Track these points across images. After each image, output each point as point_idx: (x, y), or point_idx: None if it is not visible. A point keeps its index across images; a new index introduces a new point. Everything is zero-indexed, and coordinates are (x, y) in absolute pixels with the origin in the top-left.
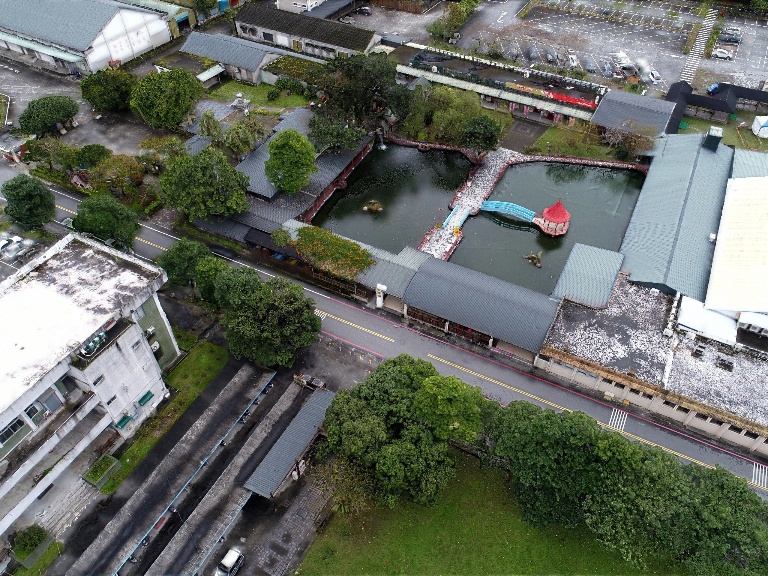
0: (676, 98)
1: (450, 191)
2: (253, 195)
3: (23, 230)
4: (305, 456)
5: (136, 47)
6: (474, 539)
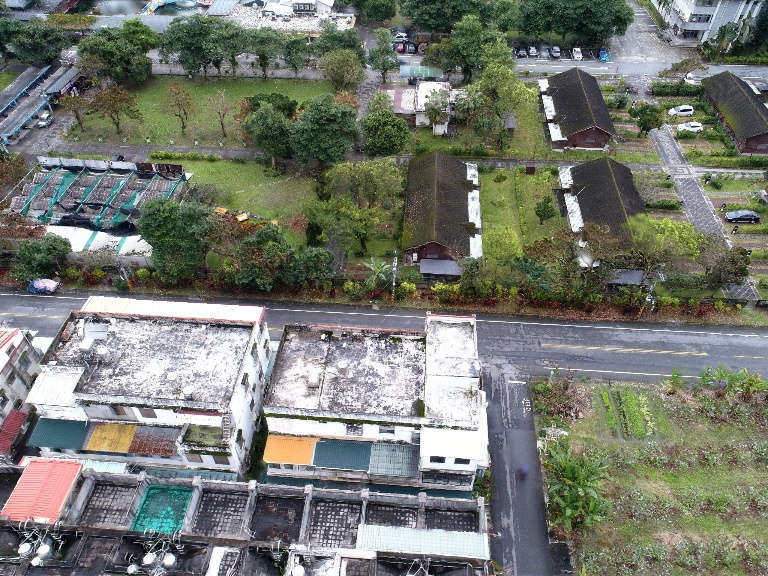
0: None
1: (146, 1)
2: None
3: None
4: (76, 85)
5: None
6: None
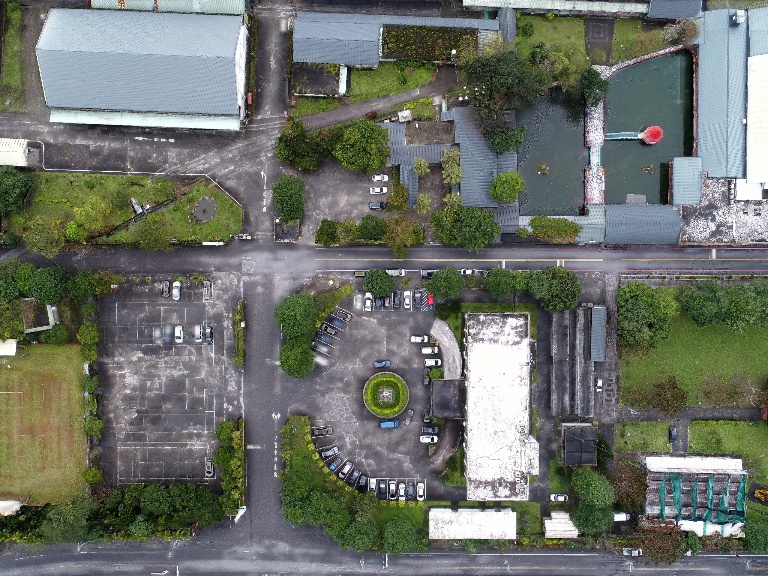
0: None
1: (577, 128)
2: (484, 208)
3: (363, 287)
4: None
5: (243, 66)
6: (675, 333)
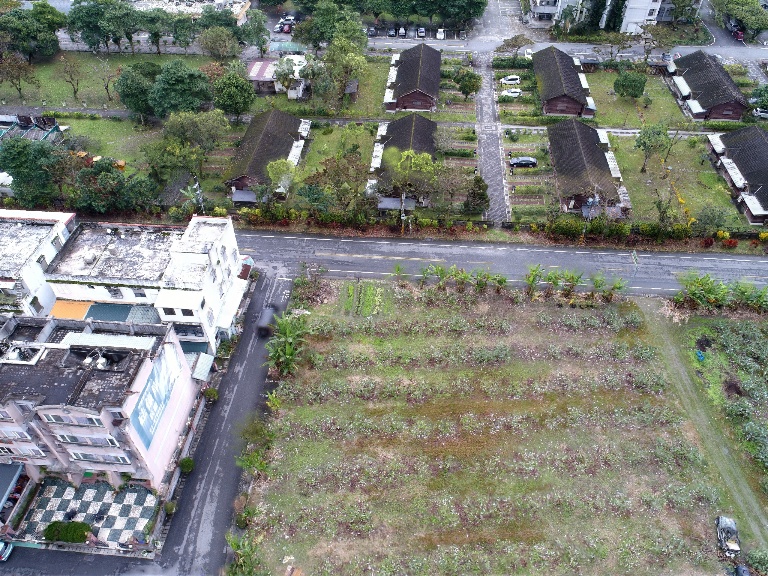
0: None
1: None
2: None
3: None
4: None
5: None
6: None
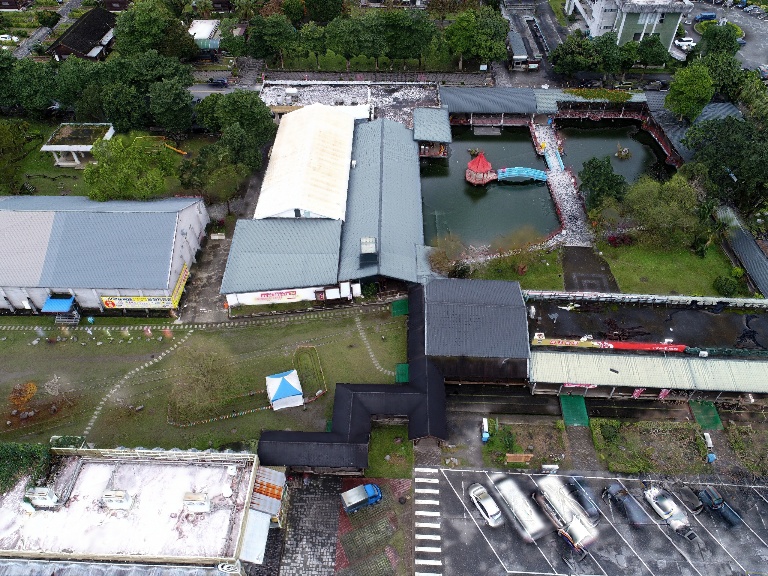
0: (429, 370)
1: None
2: None
3: None
4: None
5: None
6: None
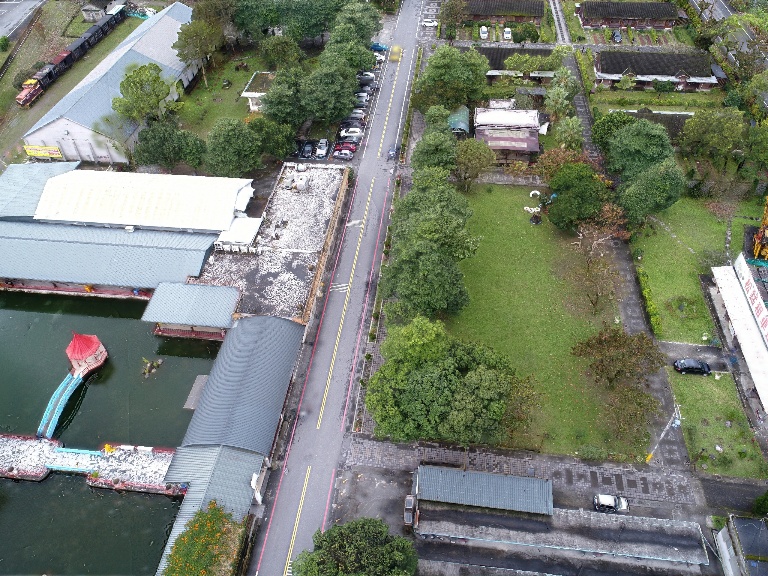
0: None
1: None
2: None
3: None
4: None
5: None
6: None
